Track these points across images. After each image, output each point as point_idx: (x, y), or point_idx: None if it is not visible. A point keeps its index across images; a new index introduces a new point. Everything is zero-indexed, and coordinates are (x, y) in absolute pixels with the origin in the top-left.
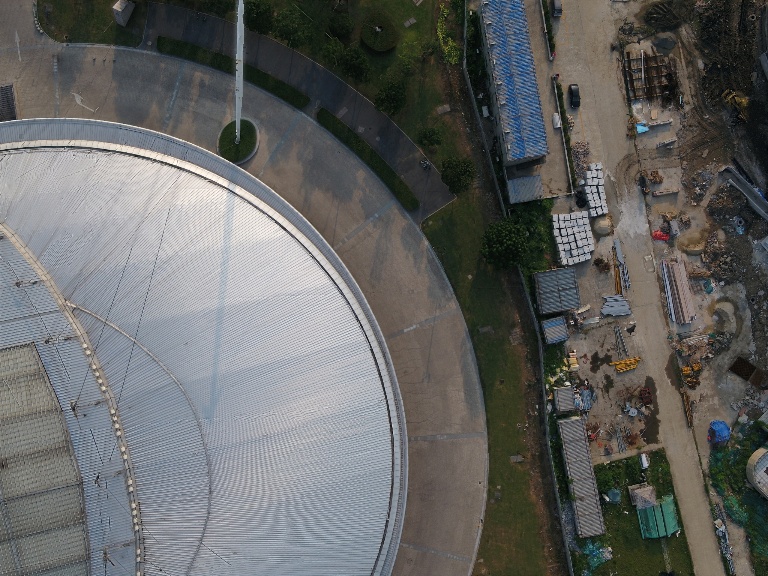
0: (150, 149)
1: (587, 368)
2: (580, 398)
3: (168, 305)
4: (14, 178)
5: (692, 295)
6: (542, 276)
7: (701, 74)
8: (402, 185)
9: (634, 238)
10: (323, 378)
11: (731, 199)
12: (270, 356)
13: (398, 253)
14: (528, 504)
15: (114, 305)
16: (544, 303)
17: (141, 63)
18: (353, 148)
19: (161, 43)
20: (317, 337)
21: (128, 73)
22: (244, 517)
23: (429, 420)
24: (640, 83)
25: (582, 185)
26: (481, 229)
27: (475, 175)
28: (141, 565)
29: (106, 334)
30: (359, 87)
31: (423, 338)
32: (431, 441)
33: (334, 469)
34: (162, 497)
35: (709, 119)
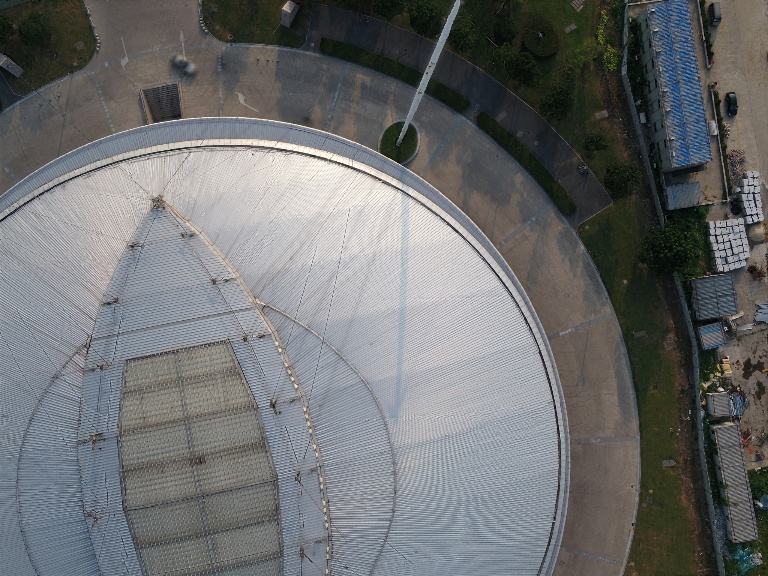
0: (320, 149)
1: (739, 374)
2: (732, 404)
3: (353, 305)
4: (196, 176)
5: None
6: (700, 282)
7: None
8: (560, 189)
9: None
10: (498, 380)
11: None
12: (450, 357)
13: (555, 257)
14: (680, 508)
15: (302, 304)
16: (702, 309)
17: (304, 64)
18: (512, 152)
19: (325, 44)
20: (492, 339)
21: (291, 74)
22: (426, 516)
23: (583, 423)
24: None
25: (737, 192)
26: (637, 234)
27: (641, 181)
28: (328, 562)
29: (296, 332)
30: (518, 91)
31: (578, 342)
32: (585, 444)
33: (508, 470)
34: (350, 495)
35: None
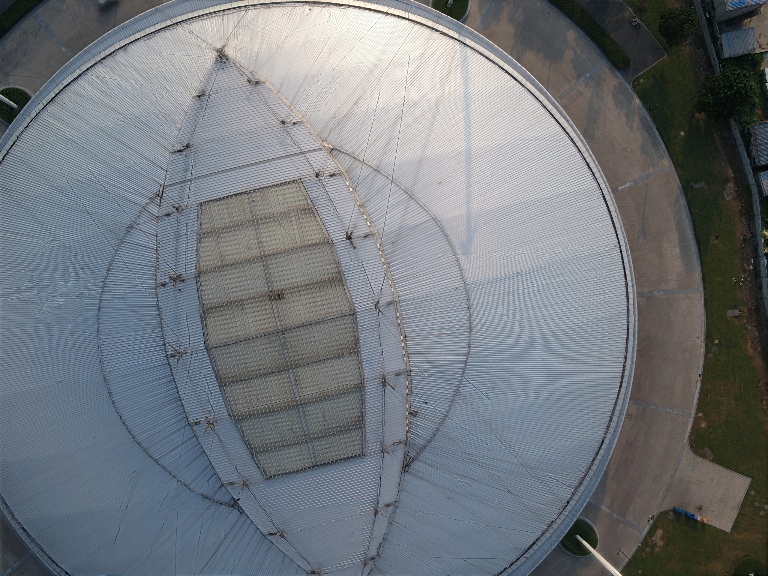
0: None
1: None
2: None
3: (419, 146)
4: (255, 31)
5: None
6: (759, 128)
7: None
8: (613, 43)
9: None
10: (564, 221)
11: None
12: (517, 197)
13: (610, 112)
14: (746, 358)
15: (369, 146)
16: (761, 154)
17: None
18: (563, 8)
19: None
20: (556, 181)
21: None
22: (501, 352)
23: (645, 276)
24: None
25: None
26: (692, 85)
27: None
28: (408, 397)
29: (365, 173)
30: None
31: (637, 195)
32: (648, 297)
33: (578, 310)
34: (427, 330)
35: None
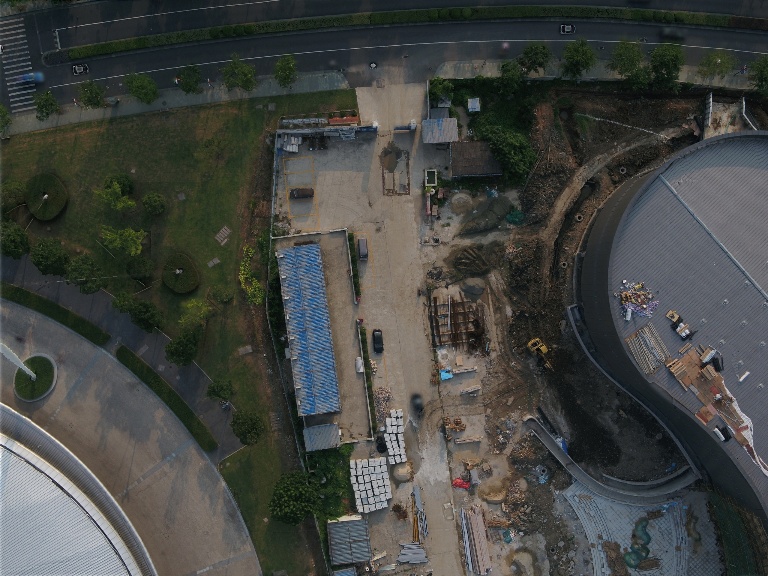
0: None
1: None
2: None
3: None
4: None
5: (491, 544)
6: (334, 527)
7: (509, 321)
8: (200, 426)
9: (434, 485)
10: None
11: (534, 449)
12: None
13: (194, 494)
14: None
15: None
16: (335, 554)
17: None
18: (152, 387)
19: None
20: None
21: None
22: None
23: None
24: (446, 329)
25: (383, 431)
26: (278, 472)
27: (262, 432)
28: None
29: None
30: None
31: None
32: None
33: None
34: None
35: (515, 366)
